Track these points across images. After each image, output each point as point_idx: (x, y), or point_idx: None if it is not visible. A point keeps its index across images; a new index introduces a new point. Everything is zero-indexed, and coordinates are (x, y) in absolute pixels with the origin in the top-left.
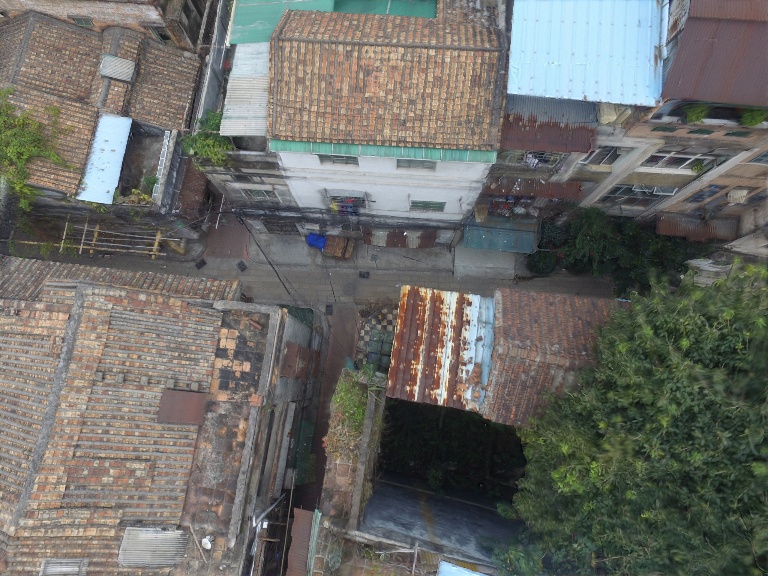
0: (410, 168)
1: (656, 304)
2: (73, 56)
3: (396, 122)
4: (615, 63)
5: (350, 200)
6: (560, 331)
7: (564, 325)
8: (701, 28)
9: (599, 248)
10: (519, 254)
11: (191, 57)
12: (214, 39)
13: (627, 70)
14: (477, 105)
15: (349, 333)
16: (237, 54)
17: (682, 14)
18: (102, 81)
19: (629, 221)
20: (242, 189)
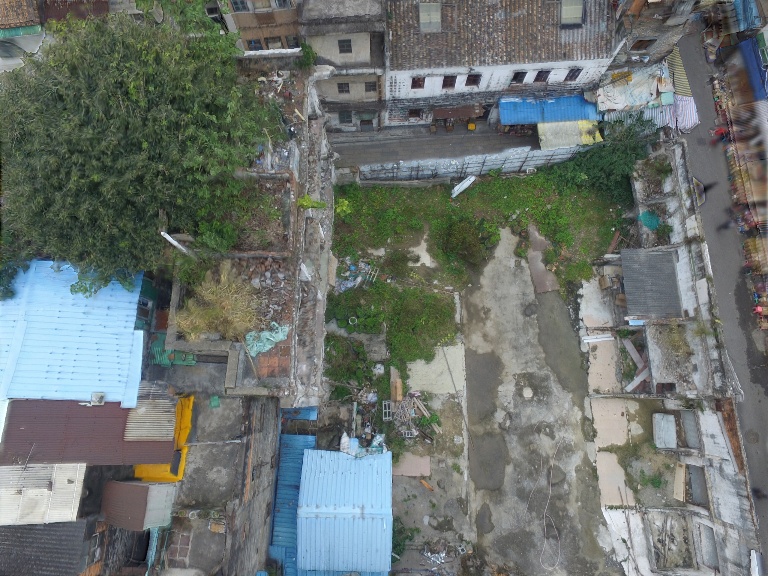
0: (13, 58)
1: None
2: None
3: None
4: None
5: None
6: None
7: None
8: None
9: None
10: None
11: None
12: None
13: None
14: None
15: None
16: None
17: None
18: None
19: None
20: None
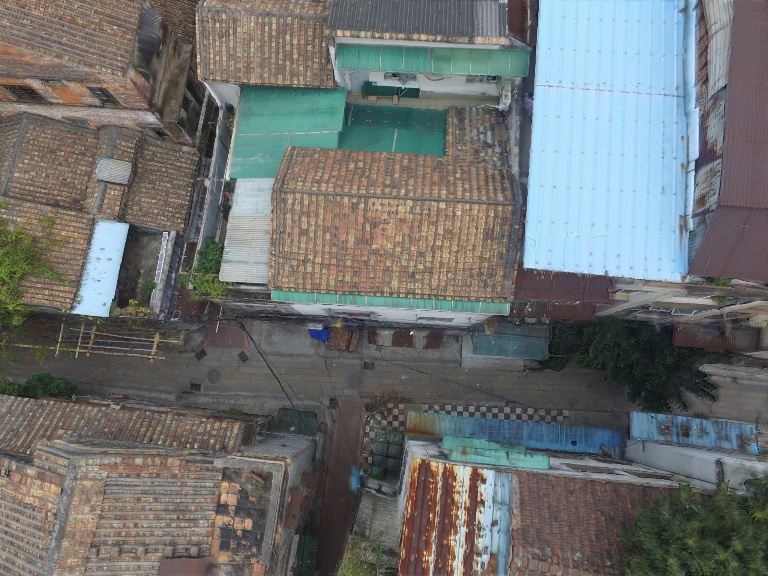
0: None
1: (691, 548)
2: (68, 157)
3: (404, 274)
4: (638, 234)
5: (355, 314)
6: (582, 533)
7: (586, 524)
8: (732, 214)
9: (613, 356)
10: (530, 360)
11: (190, 151)
12: (213, 161)
13: (651, 242)
14: (490, 258)
15: (354, 428)
16: (237, 190)
17: (710, 194)
18: (98, 185)
19: (644, 327)
20: (243, 305)
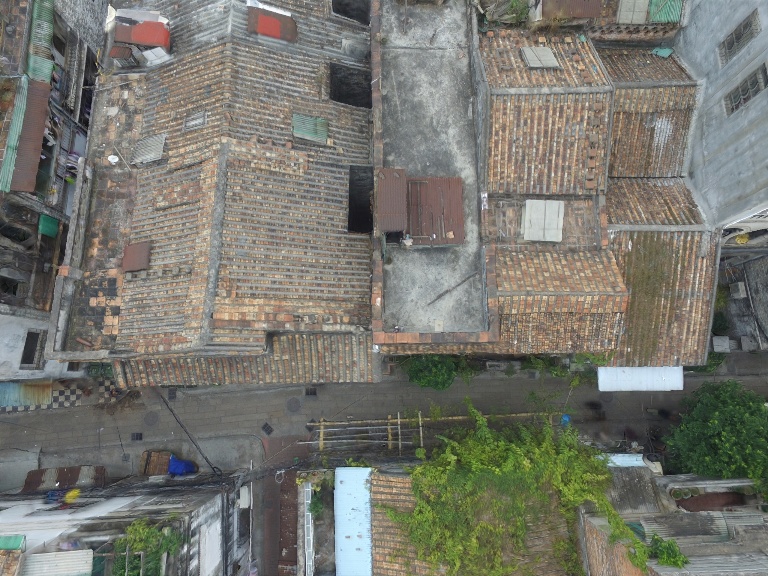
0: None
1: None
2: None
3: None
4: None
5: None
6: None
7: None
8: None
9: None
10: None
11: None
12: None
13: None
14: None
15: None
16: None
17: None
18: None
19: None
20: None
